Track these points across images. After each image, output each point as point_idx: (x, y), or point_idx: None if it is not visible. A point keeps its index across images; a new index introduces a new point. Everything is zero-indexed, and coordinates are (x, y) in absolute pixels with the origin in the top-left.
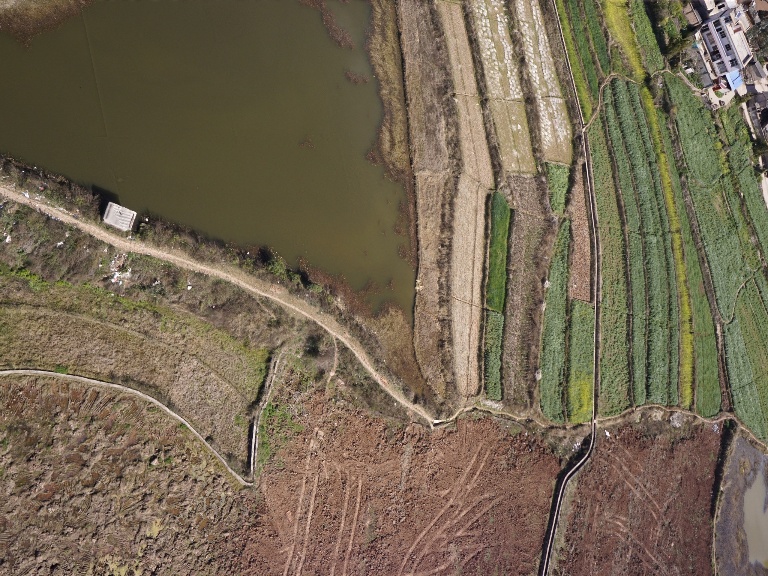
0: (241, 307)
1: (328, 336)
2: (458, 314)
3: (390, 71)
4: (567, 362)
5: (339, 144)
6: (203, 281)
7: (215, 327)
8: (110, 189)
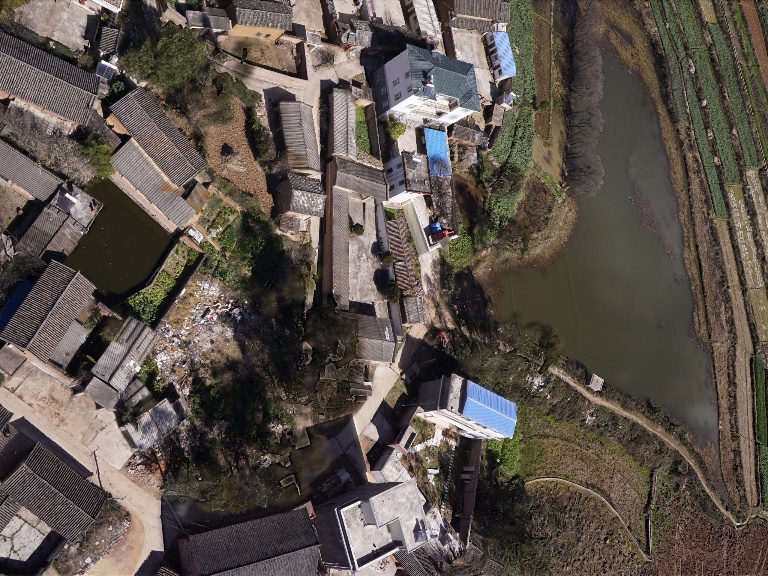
0: (644, 440)
1: (685, 461)
2: (743, 446)
3: (694, 273)
4: None
5: (675, 326)
6: (627, 423)
7: (627, 453)
8: (583, 363)
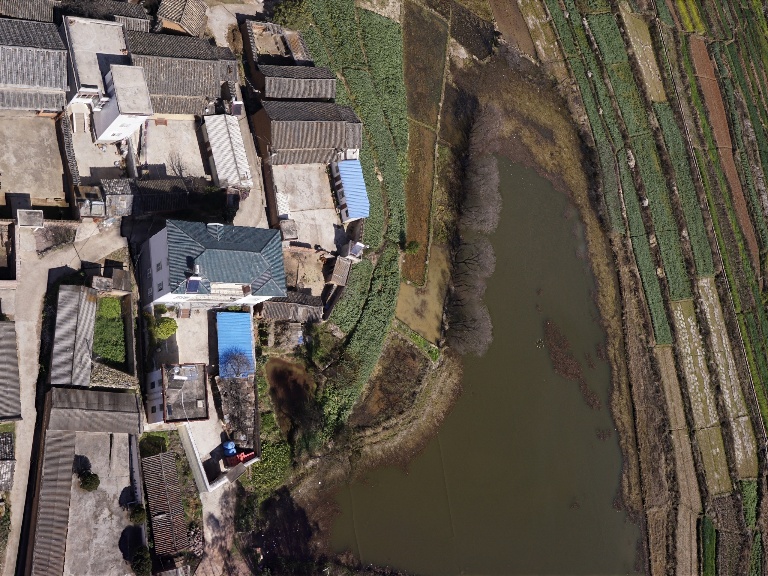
0: None
1: None
2: None
3: (625, 421)
4: None
5: (595, 499)
6: None
7: None
8: None
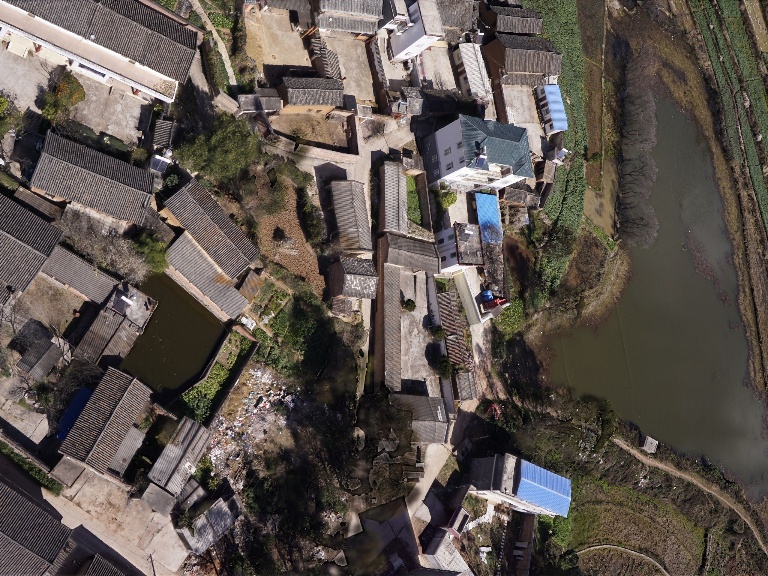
0: (699, 500)
1: (741, 519)
2: None
3: (749, 318)
4: None
5: (730, 377)
6: (681, 483)
7: (681, 513)
8: (636, 424)
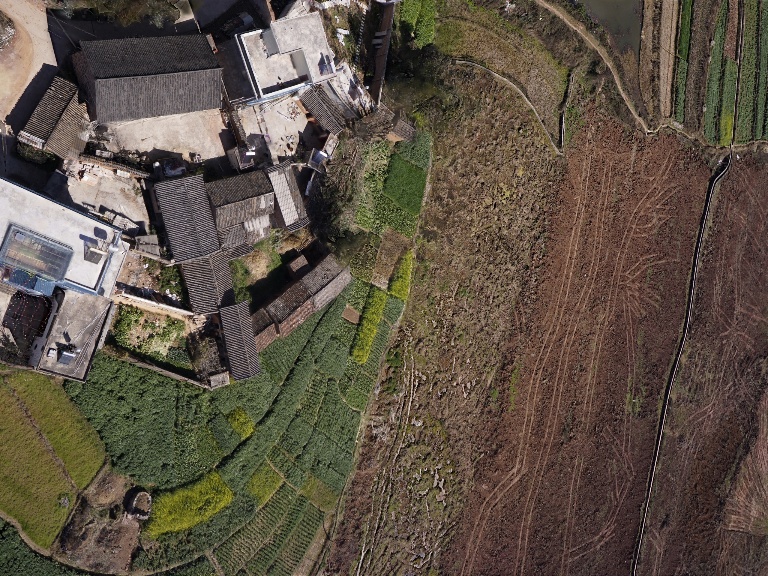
0: (564, 35)
1: (603, 62)
2: (662, 58)
3: None
4: (720, 102)
5: None
6: (548, 15)
7: (546, 49)
8: None
